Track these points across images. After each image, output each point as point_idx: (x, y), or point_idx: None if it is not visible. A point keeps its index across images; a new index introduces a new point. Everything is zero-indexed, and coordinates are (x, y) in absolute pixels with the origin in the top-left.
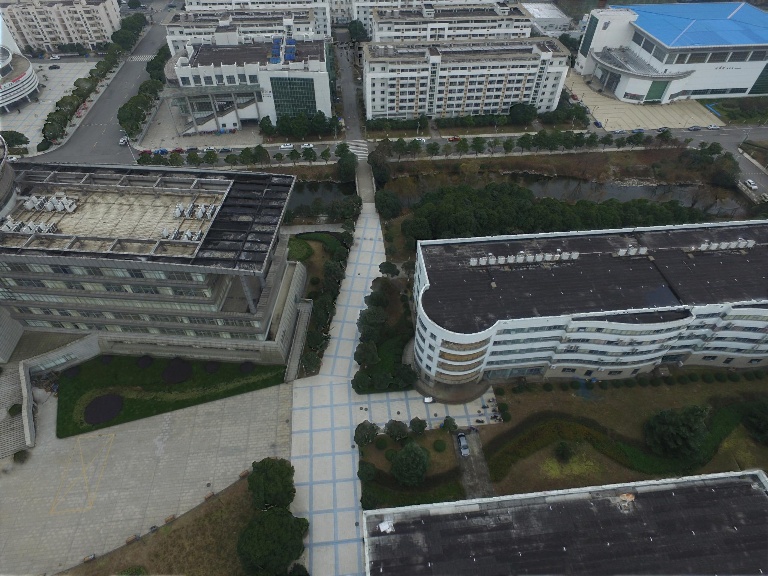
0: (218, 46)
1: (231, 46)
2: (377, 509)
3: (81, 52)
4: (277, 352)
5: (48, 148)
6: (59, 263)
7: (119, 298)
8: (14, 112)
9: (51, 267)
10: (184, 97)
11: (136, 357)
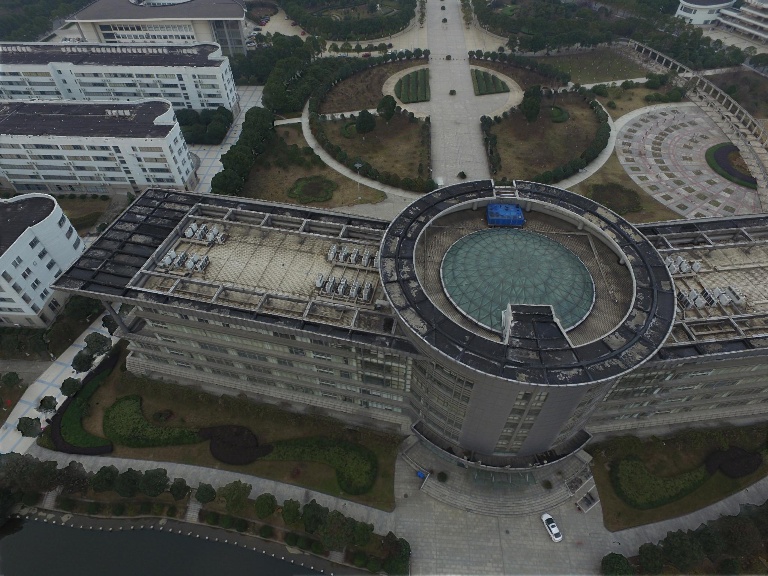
0: None
1: None
2: (158, 139)
3: None
4: None
5: None
6: None
7: None
8: None
9: None
10: None
11: None
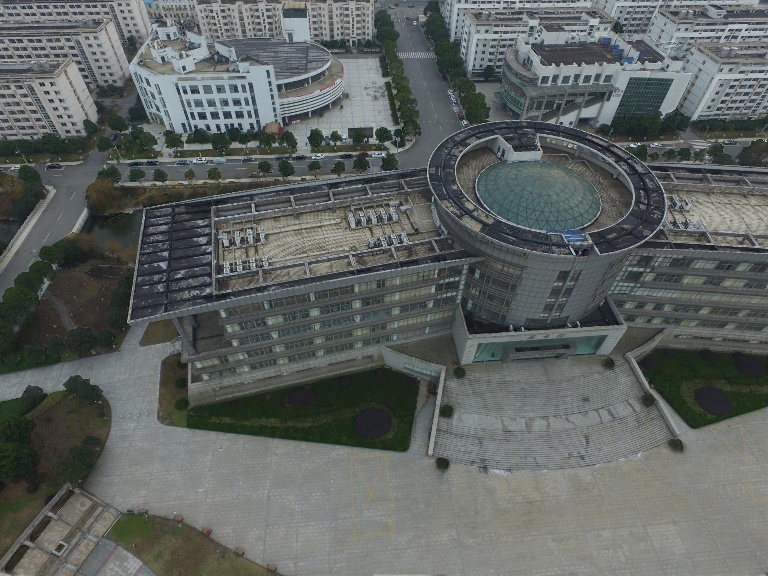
0: (546, 45)
1: (558, 45)
2: None
3: (347, 48)
4: None
5: (405, 144)
6: (767, 260)
7: (749, 294)
8: (335, 108)
9: (719, 263)
10: (544, 96)
11: (694, 351)
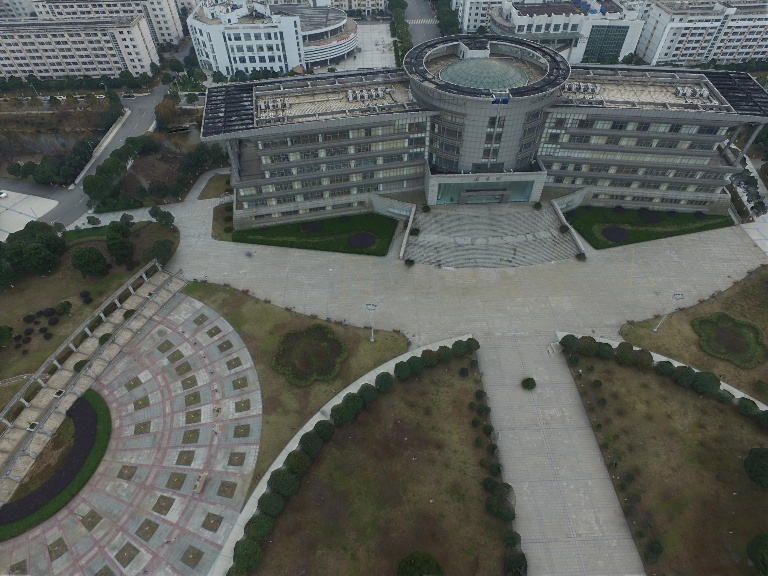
0: (526, 4)
1: (537, 4)
2: None
3: None
4: (727, 203)
5: None
6: (642, 115)
7: (641, 152)
8: (350, 59)
9: (613, 124)
10: None
11: (609, 208)
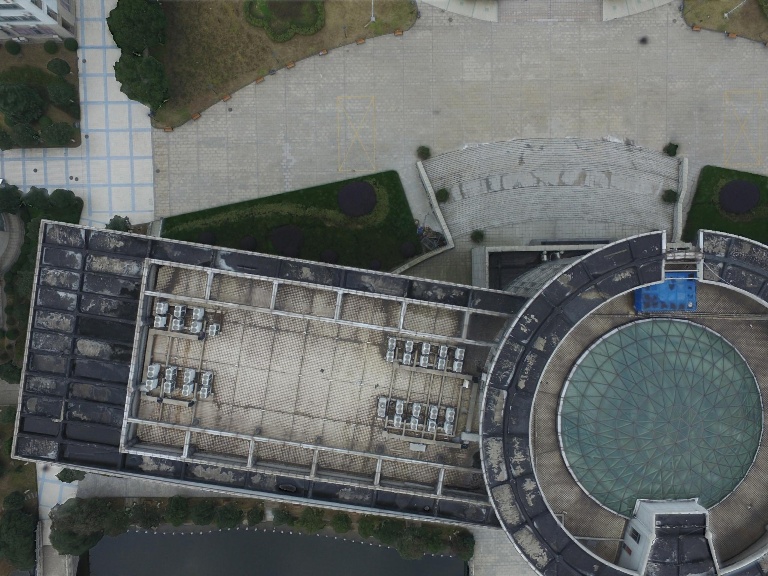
0: None
1: None
2: None
3: None
4: None
5: None
6: None
7: None
8: None
9: None
10: None
11: None
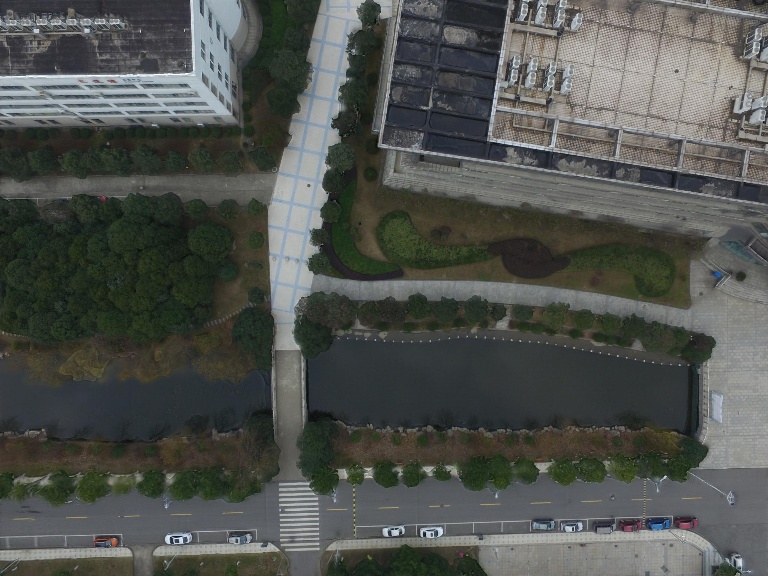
0: None
1: None
2: None
3: None
4: None
5: None
6: None
7: None
8: None
9: None
10: None
11: None
